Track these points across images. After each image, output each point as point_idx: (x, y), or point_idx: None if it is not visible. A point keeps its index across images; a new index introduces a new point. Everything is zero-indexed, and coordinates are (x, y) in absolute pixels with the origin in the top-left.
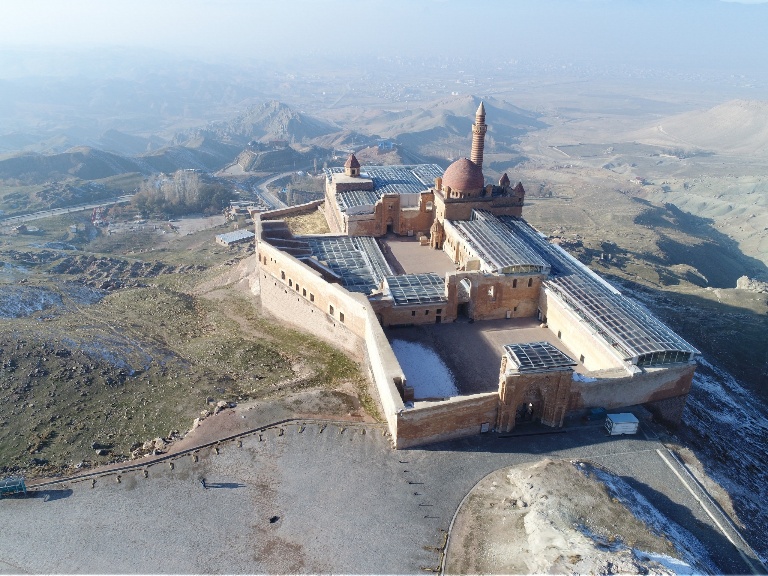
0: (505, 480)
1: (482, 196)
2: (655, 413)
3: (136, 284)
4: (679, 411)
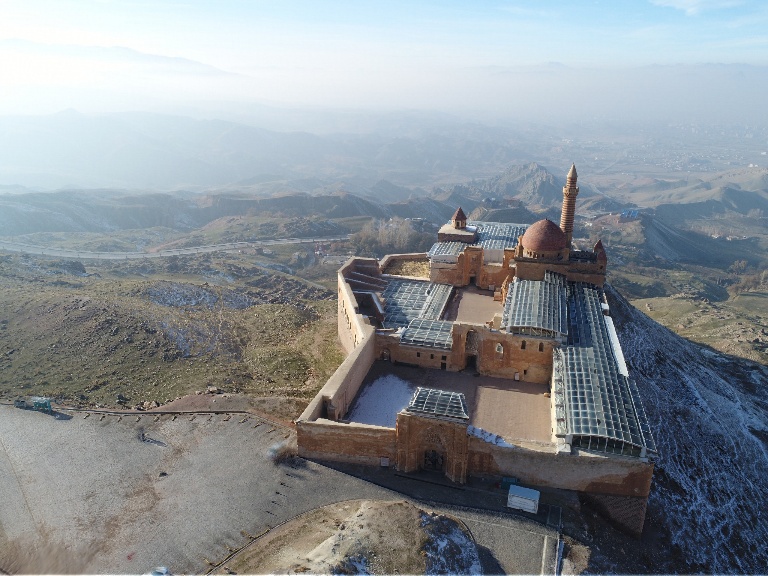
0: (357, 507)
1: (559, 259)
2: (599, 508)
3: (296, 303)
4: (635, 516)
